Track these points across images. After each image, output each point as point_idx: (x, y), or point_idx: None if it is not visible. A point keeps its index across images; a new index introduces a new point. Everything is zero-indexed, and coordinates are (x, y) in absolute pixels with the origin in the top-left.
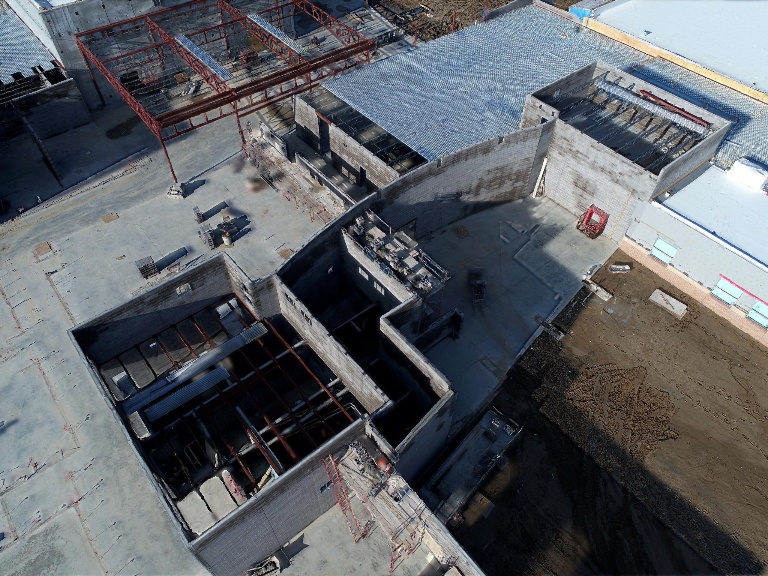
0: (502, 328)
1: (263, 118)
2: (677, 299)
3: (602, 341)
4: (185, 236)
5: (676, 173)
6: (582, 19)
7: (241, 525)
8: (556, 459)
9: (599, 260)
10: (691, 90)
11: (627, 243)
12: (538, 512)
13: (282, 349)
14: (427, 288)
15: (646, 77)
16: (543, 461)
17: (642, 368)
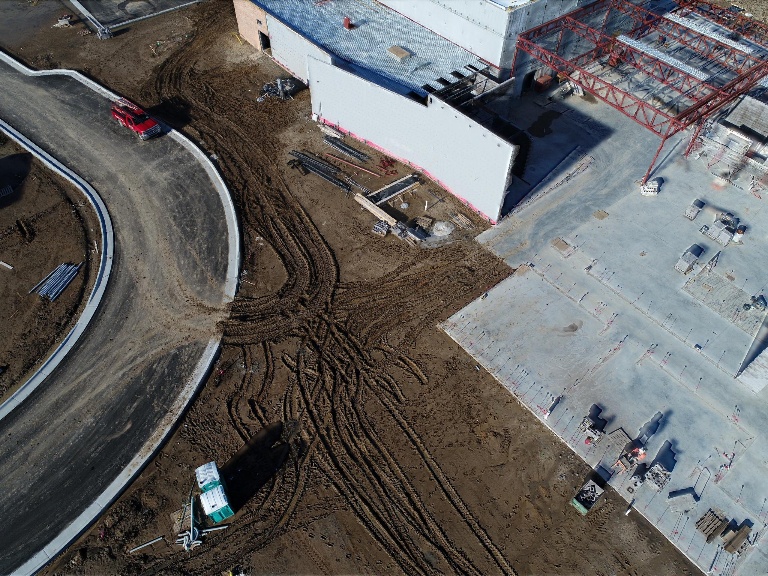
0: None
1: None
2: None
3: None
4: (688, 233)
5: None
6: None
7: None
8: None
9: None
10: None
11: None
12: None
13: None
14: None
15: None
16: None
17: None
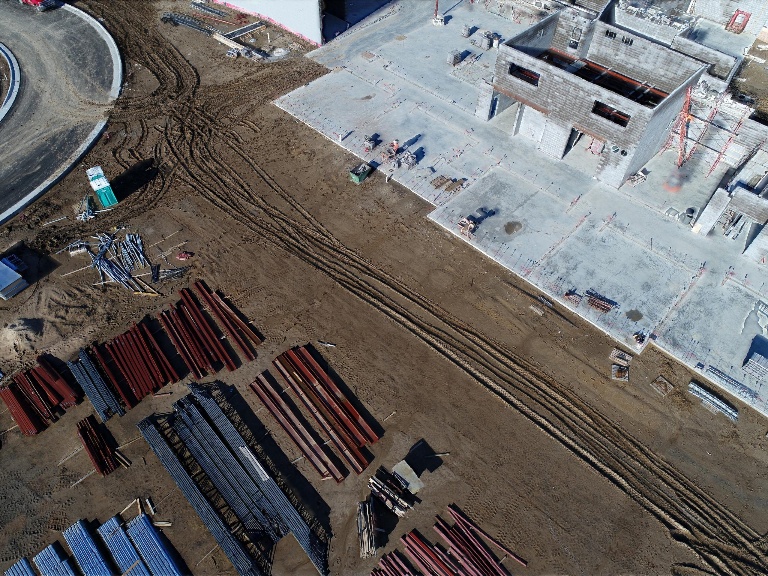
0: None
1: None
2: None
3: None
4: (462, 45)
5: None
6: None
7: None
8: None
9: (748, 44)
10: None
11: (765, 32)
12: None
13: (601, 71)
14: (691, 25)
15: None
16: None
17: None
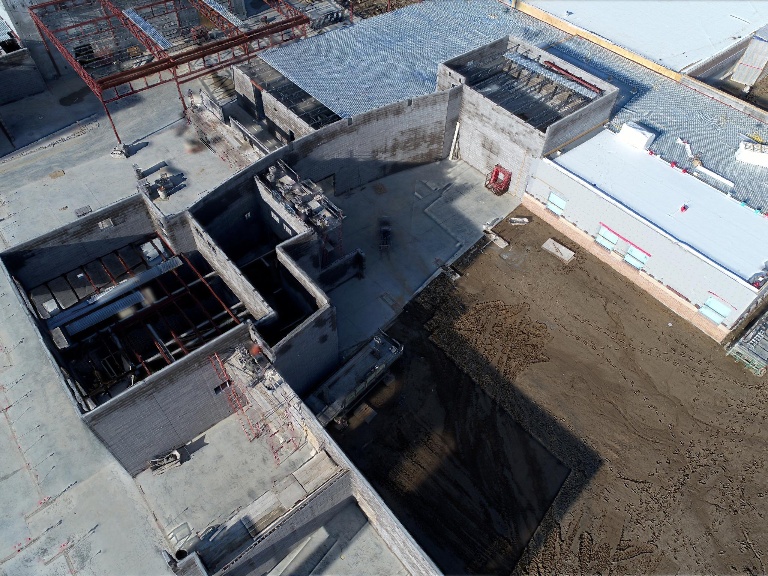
0: (405, 270)
1: (208, 89)
2: (567, 247)
3: (494, 282)
4: (125, 190)
5: (566, 133)
6: (511, 1)
7: (133, 408)
8: (437, 377)
9: (501, 214)
10: (601, 64)
11: (527, 199)
12: (415, 419)
13: (194, 278)
14: (322, 224)
15: (561, 53)
16: (426, 379)
17: (526, 304)
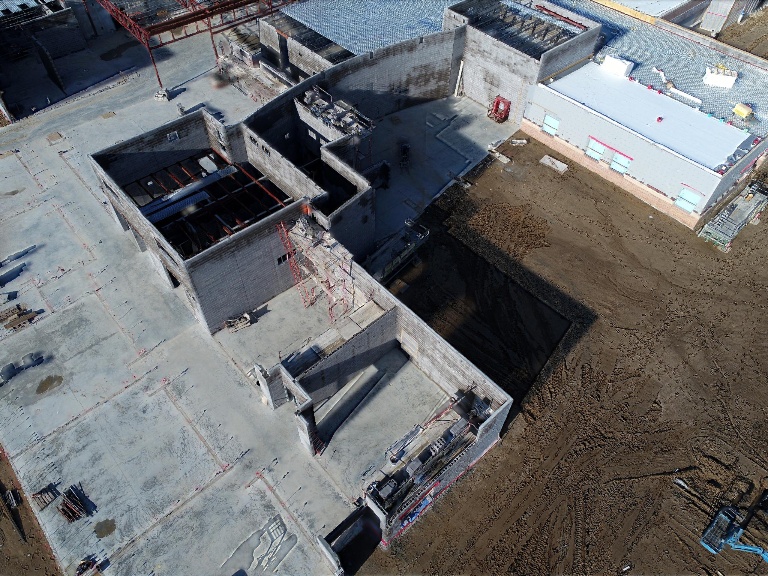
0: (423, 181)
1: None
2: (561, 162)
3: (500, 189)
4: None
5: (557, 62)
6: None
7: (220, 262)
8: (457, 260)
9: (503, 137)
10: (584, 12)
11: (525, 124)
12: (441, 290)
13: (249, 181)
14: (357, 131)
15: None
16: (448, 261)
17: (528, 205)
